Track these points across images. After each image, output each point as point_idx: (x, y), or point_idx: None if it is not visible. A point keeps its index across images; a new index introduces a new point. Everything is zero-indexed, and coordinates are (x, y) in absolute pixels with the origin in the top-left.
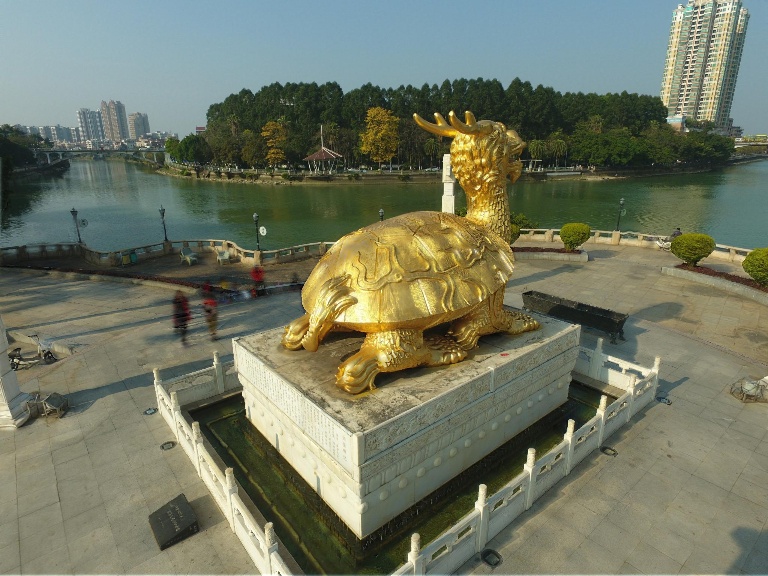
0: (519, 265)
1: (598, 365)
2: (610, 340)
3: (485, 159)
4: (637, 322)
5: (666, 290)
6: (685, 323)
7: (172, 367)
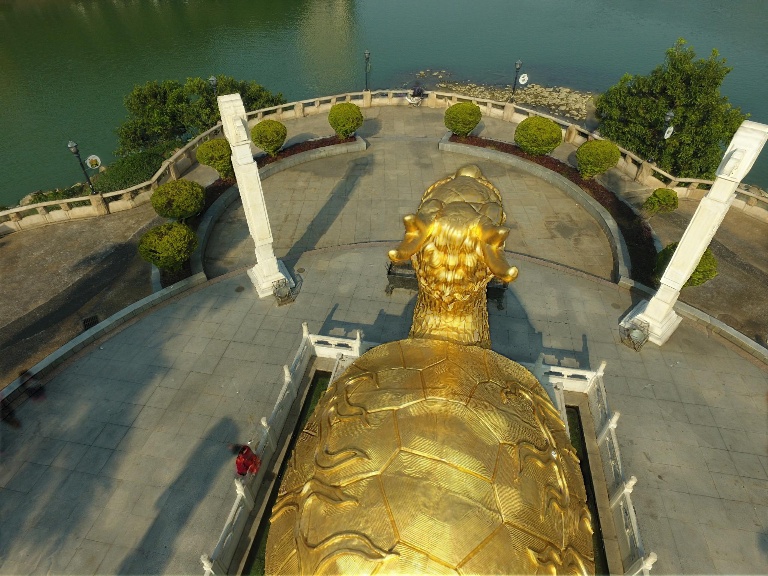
0: (304, 179)
1: (538, 376)
2: (494, 304)
3: None
4: None
5: None
6: None
7: None
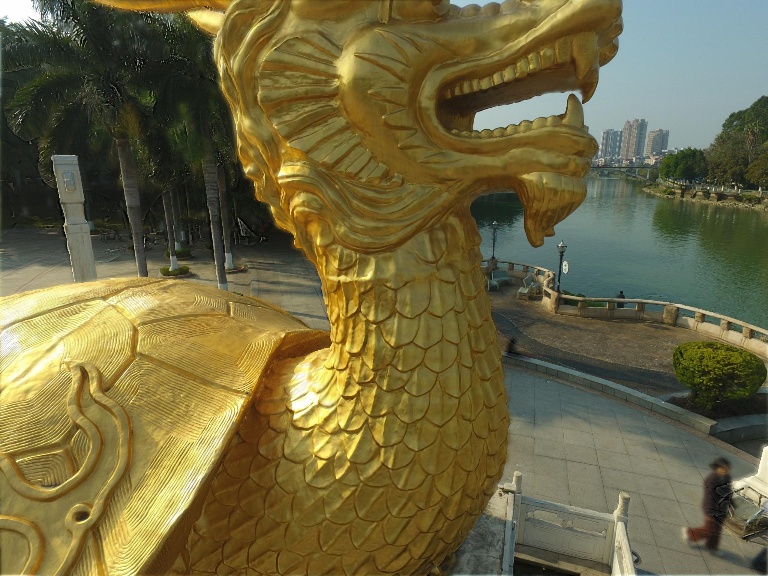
0: None
1: None
2: None
3: None
4: None
5: None
6: None
7: None
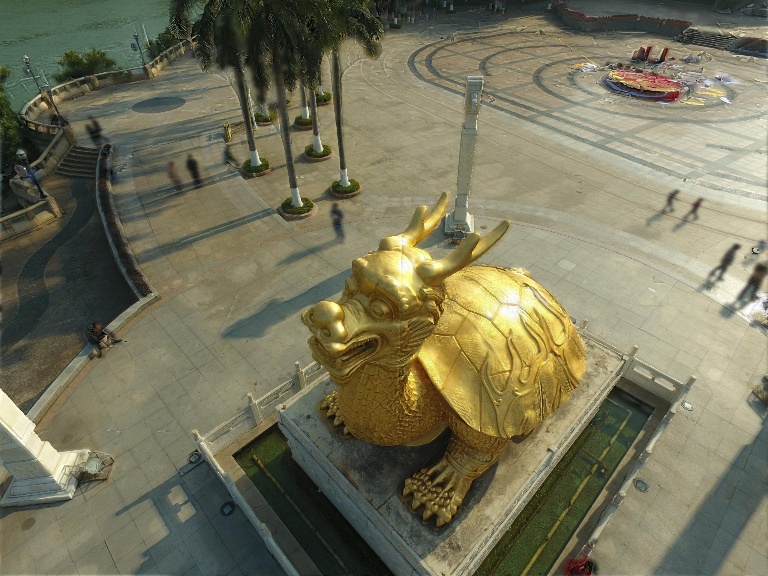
0: None
1: None
2: None
3: None
4: None
5: None
6: None
7: None
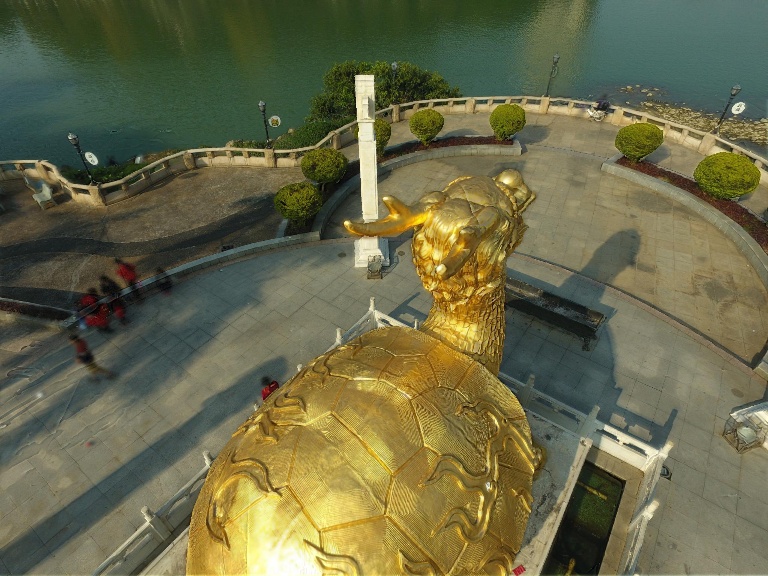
0: (446, 171)
1: (589, 430)
2: (581, 342)
3: (484, 275)
4: (601, 293)
5: (612, 206)
6: (643, 273)
7: (2, 549)
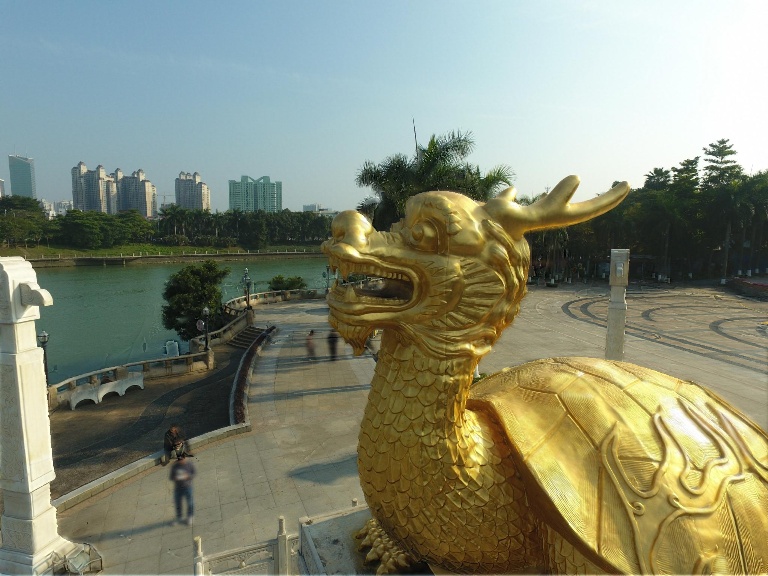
0: None
1: None
2: None
3: None
4: None
5: None
6: None
7: None
